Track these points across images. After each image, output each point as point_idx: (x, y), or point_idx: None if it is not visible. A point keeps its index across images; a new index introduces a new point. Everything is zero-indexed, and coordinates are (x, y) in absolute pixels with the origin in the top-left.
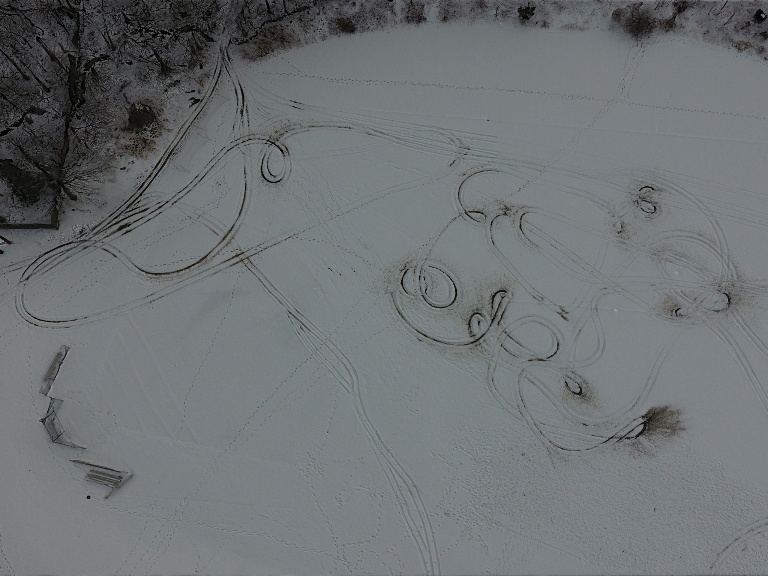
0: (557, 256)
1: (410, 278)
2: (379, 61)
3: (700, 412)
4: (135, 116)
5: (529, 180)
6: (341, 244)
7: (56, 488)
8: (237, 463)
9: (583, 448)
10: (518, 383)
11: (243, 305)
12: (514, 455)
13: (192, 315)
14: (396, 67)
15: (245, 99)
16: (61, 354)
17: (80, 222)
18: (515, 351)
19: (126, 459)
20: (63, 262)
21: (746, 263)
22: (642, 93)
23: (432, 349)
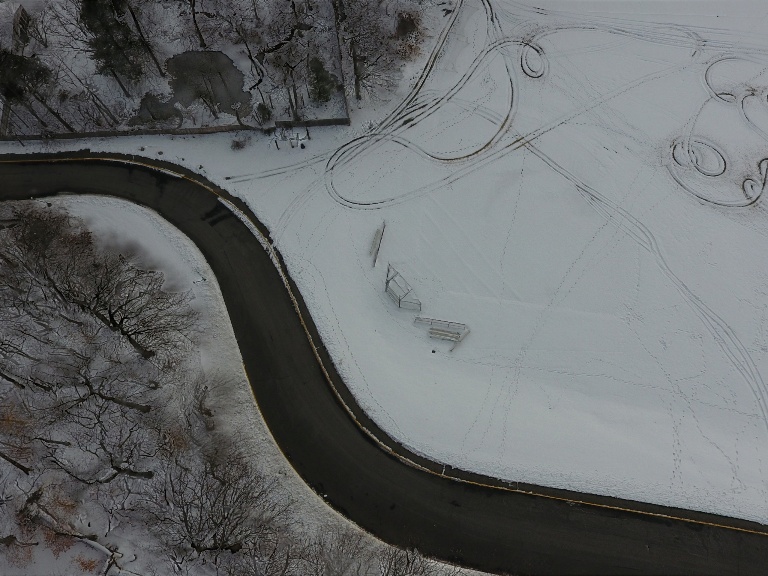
0: None
1: (680, 152)
2: None
3: None
4: (403, 23)
5: (767, 65)
6: (610, 126)
7: (403, 345)
8: (562, 316)
9: None
10: None
11: (534, 182)
12: None
13: (489, 193)
14: None
15: (493, 8)
16: (379, 231)
17: (368, 119)
18: None
19: (460, 318)
20: (361, 153)
21: None
22: None
23: (715, 211)
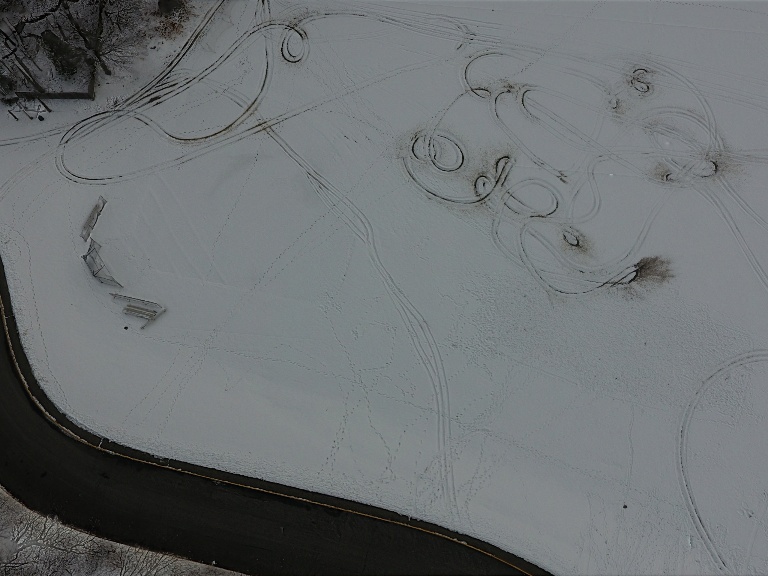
0: (557, 128)
1: (420, 145)
2: None
3: (688, 262)
4: (164, 0)
5: (531, 62)
6: (356, 115)
7: (96, 319)
8: (262, 301)
9: (580, 291)
10: (520, 236)
11: (266, 167)
12: (516, 297)
13: (219, 175)
14: None
15: None
16: (99, 206)
17: (114, 94)
18: (517, 208)
19: (160, 296)
20: (99, 128)
21: (732, 136)
22: None
23: (441, 206)
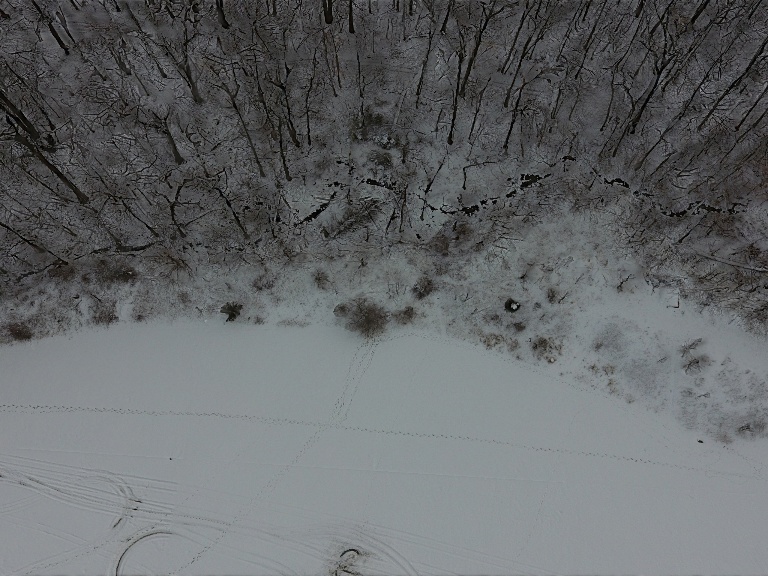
0: None
1: None
2: (53, 378)
3: None
4: None
5: (207, 545)
6: None
7: None
8: None
9: None
10: None
11: None
12: None
13: None
14: (72, 386)
15: None
16: None
17: None
18: None
19: None
20: None
21: None
22: (363, 412)
23: None
